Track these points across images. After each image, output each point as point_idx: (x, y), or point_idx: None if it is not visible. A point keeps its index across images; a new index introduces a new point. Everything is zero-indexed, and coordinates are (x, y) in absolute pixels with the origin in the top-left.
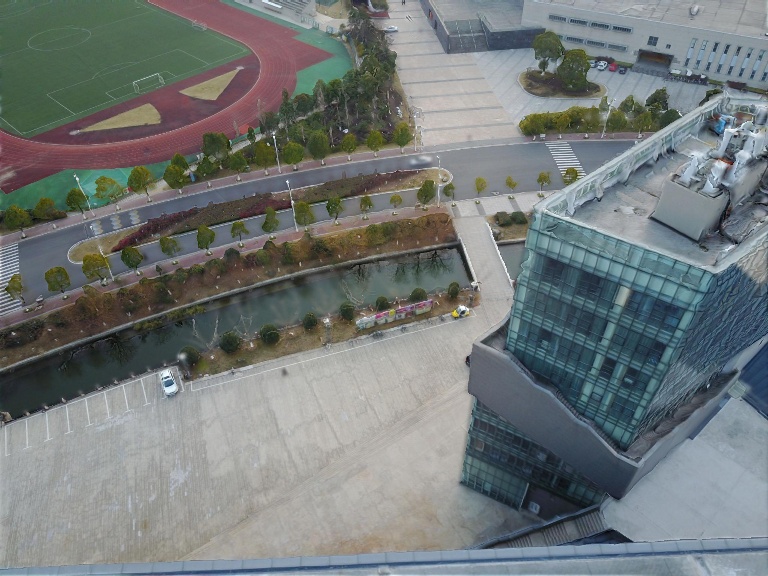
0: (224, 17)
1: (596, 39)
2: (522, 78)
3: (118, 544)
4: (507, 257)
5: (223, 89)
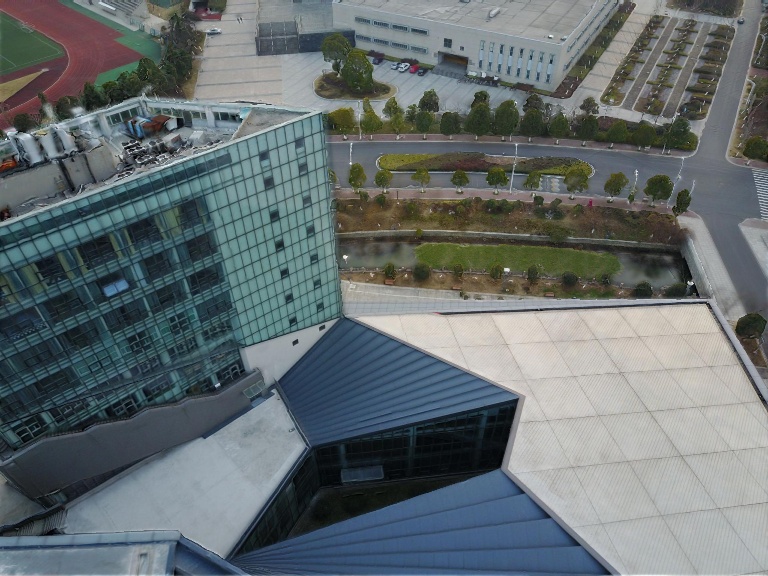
0: (58, 19)
1: (399, 41)
2: (318, 80)
3: None
4: None
5: (16, 91)
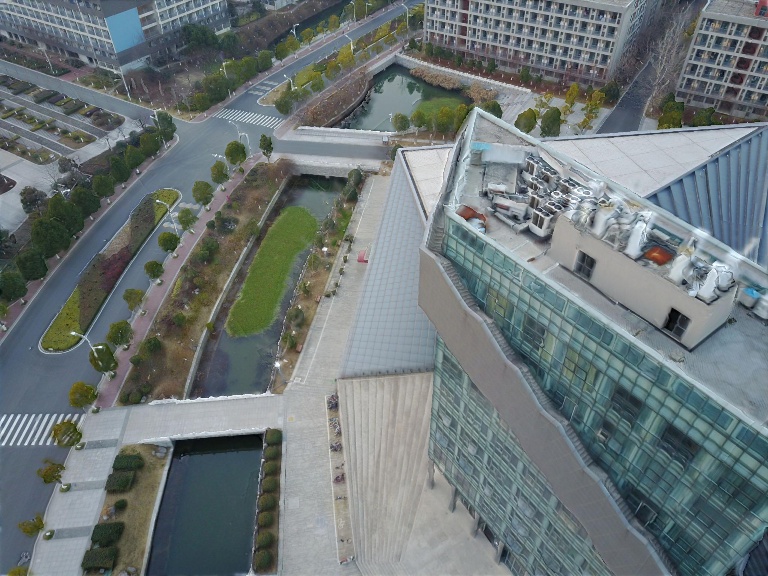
0: None
1: None
2: None
3: None
4: (172, 573)
5: None
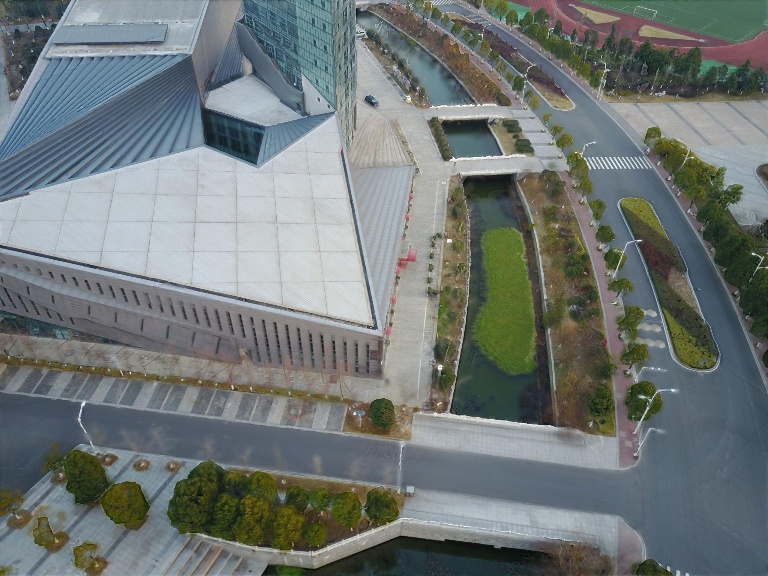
0: None
1: None
2: None
3: None
4: None
5: (659, 37)
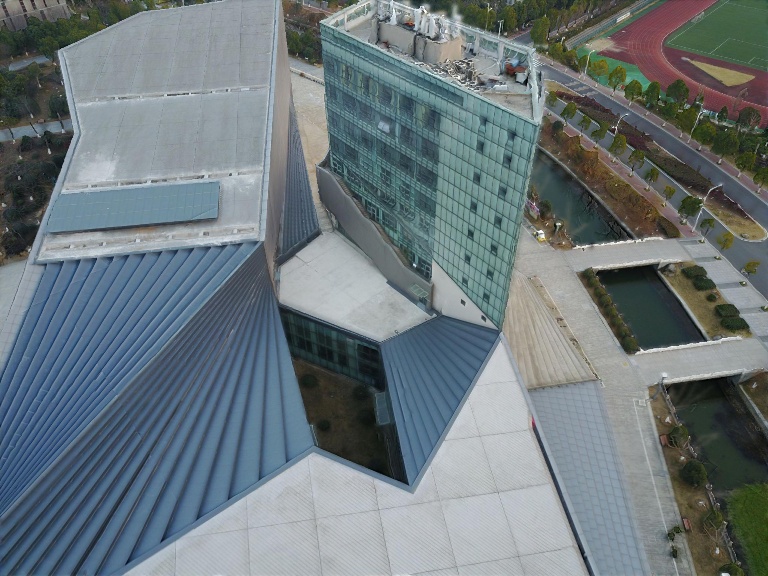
0: None
1: None
2: None
3: None
4: (646, 286)
5: None
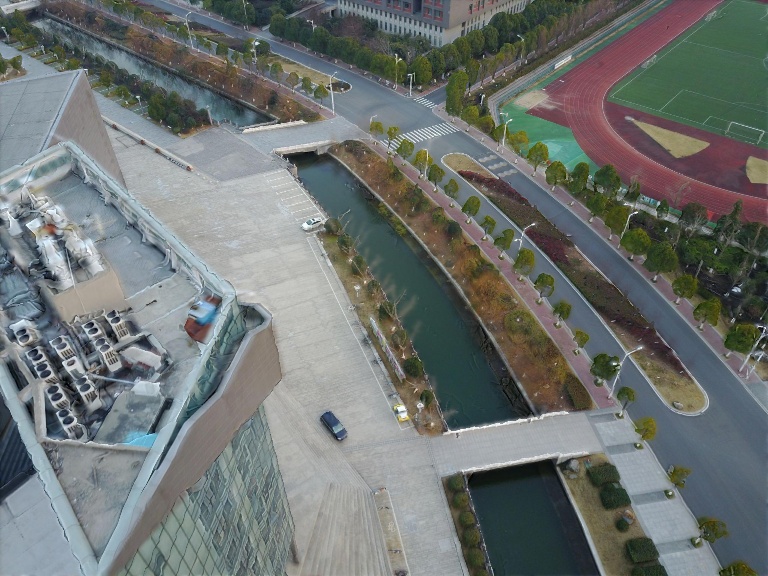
0: None
1: None
2: None
3: (191, 229)
4: (540, 489)
5: None
